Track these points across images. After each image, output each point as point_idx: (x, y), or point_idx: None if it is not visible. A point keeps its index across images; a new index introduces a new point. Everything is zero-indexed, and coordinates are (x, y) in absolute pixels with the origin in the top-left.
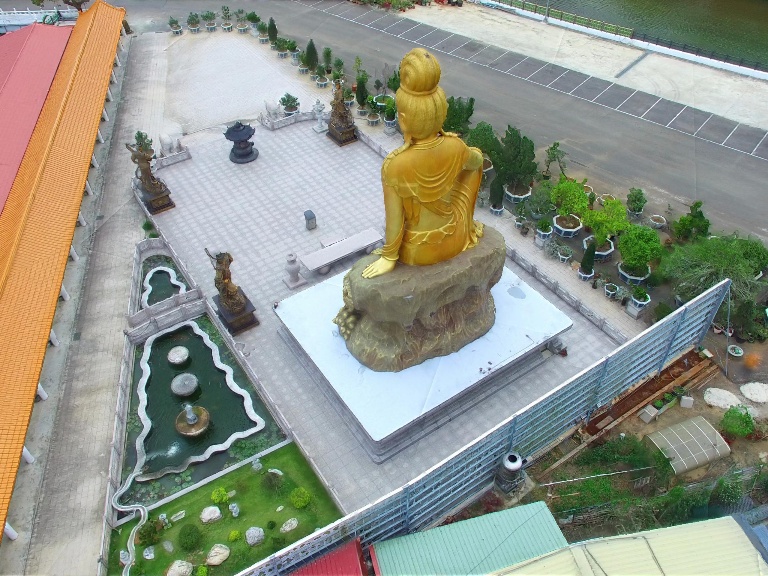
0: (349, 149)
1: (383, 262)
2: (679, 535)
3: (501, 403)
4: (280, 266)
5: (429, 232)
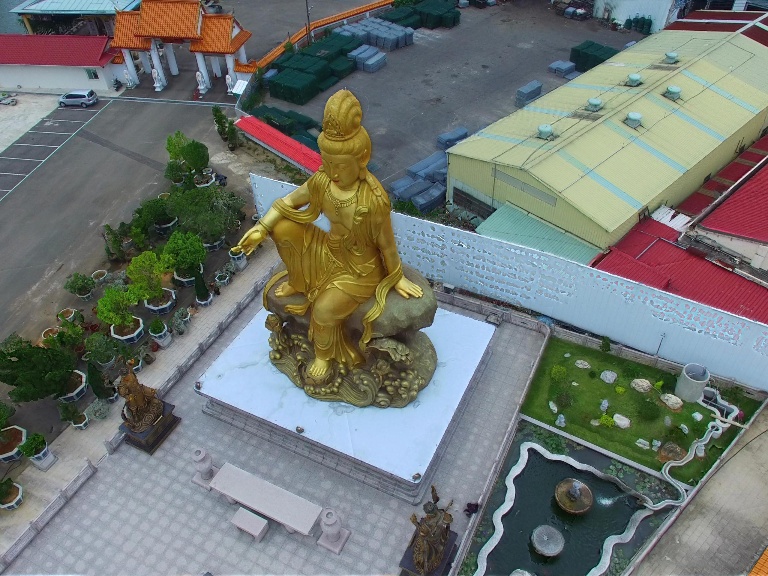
0: None
1: (405, 279)
2: None
3: None
4: None
5: None
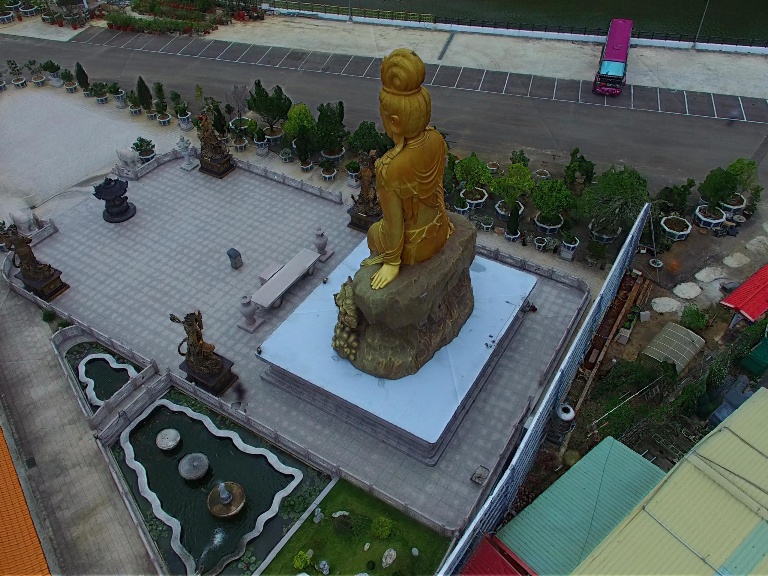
0: (231, 179)
1: (389, 269)
2: (744, 415)
3: (507, 370)
4: (226, 313)
5: (426, 227)
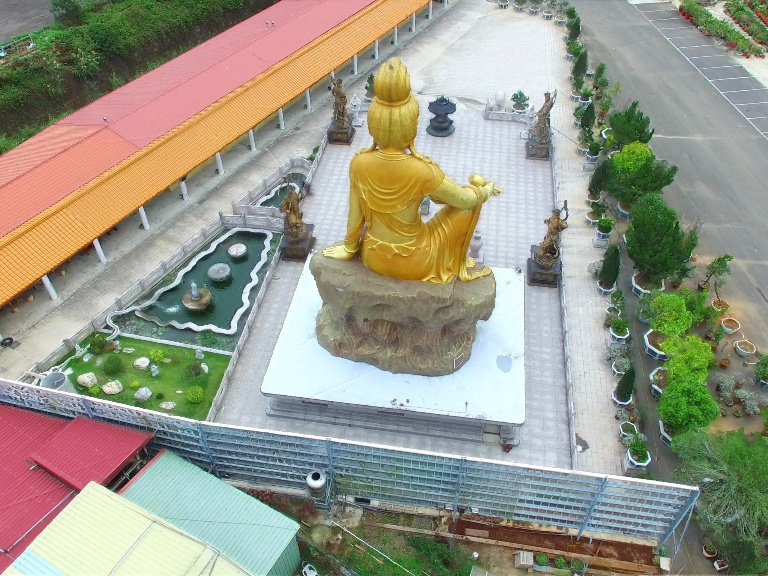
0: (532, 164)
1: (342, 248)
2: None
3: (404, 444)
4: None
5: (380, 241)
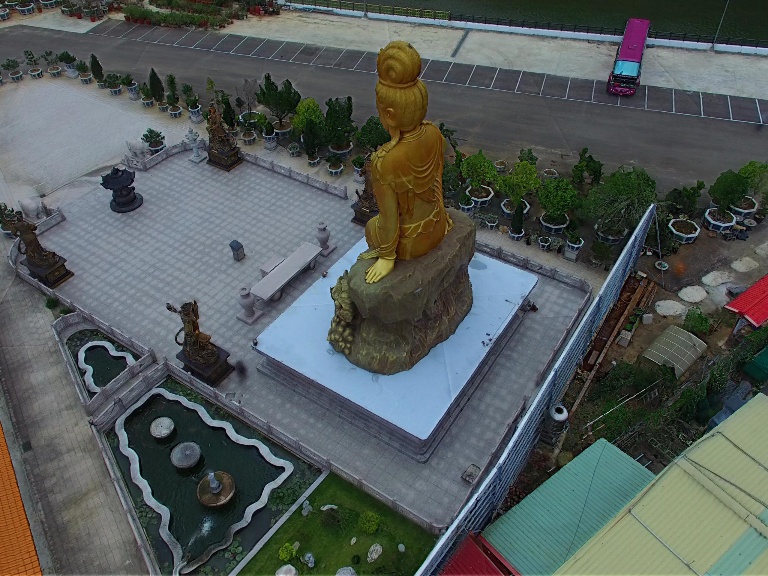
0: (238, 172)
1: (384, 263)
2: (739, 421)
3: (504, 369)
4: (226, 305)
5: (422, 222)
